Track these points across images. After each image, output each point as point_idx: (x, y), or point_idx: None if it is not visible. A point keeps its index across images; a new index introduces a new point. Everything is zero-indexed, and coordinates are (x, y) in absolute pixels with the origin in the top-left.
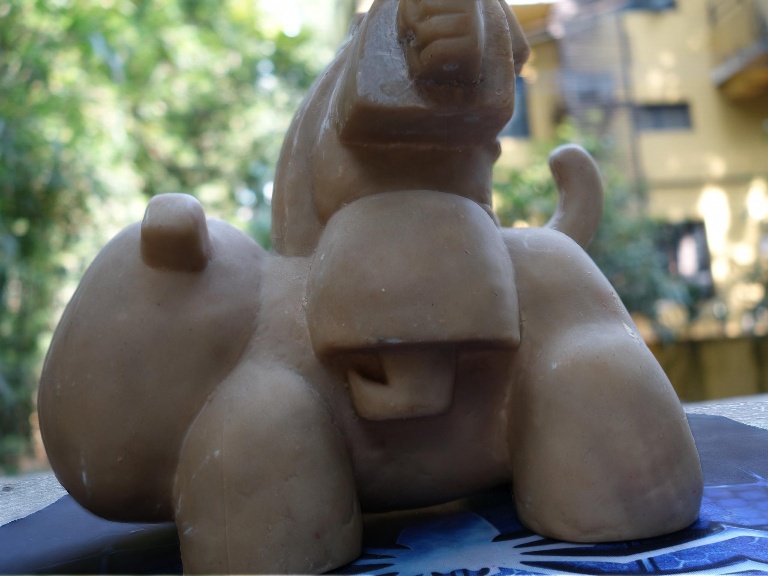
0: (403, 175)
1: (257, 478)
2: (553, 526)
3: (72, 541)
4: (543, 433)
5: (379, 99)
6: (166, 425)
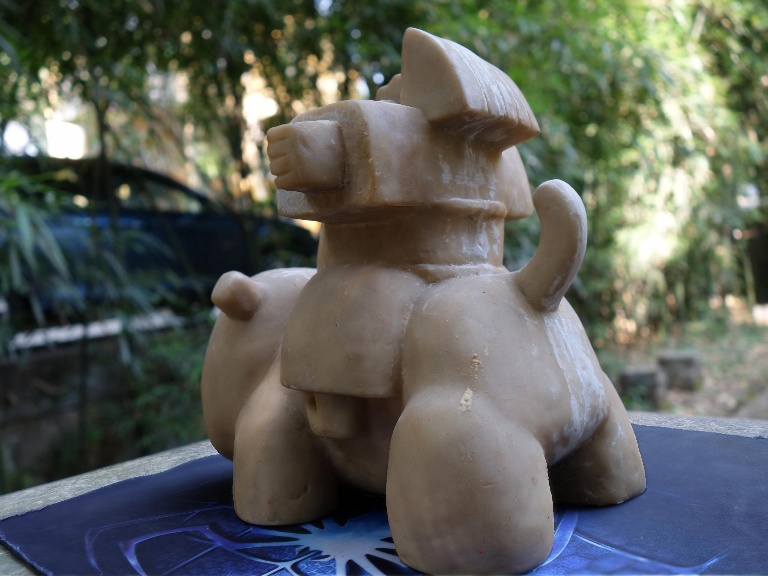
0: (347, 249)
1: (245, 459)
2: None
3: None
4: None
5: (287, 210)
6: (227, 415)
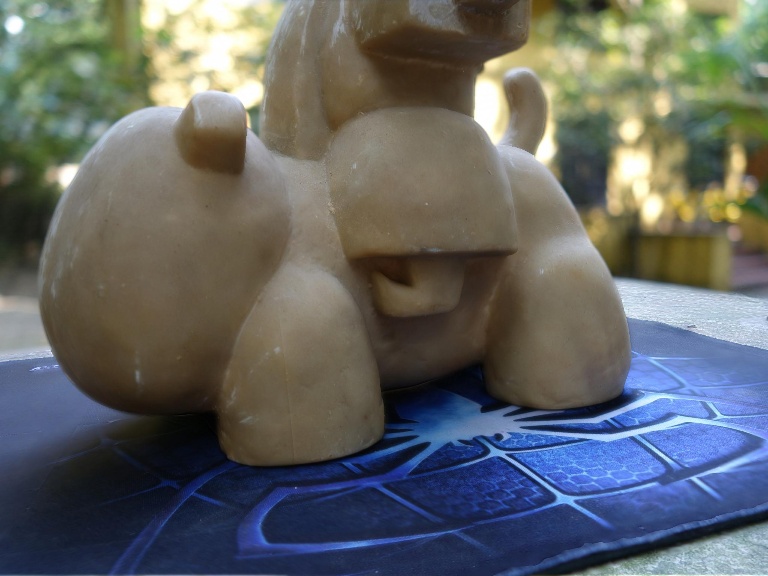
0: (419, 91)
1: (317, 371)
2: (533, 398)
3: (49, 435)
4: (532, 326)
5: (427, 20)
6: (222, 324)
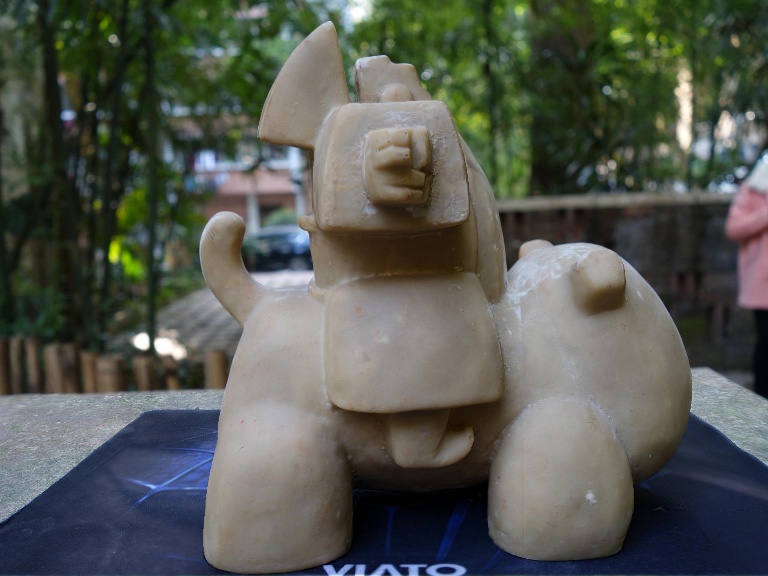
0: None
1: None
2: None
3: (705, 502)
4: None
5: None
6: None
